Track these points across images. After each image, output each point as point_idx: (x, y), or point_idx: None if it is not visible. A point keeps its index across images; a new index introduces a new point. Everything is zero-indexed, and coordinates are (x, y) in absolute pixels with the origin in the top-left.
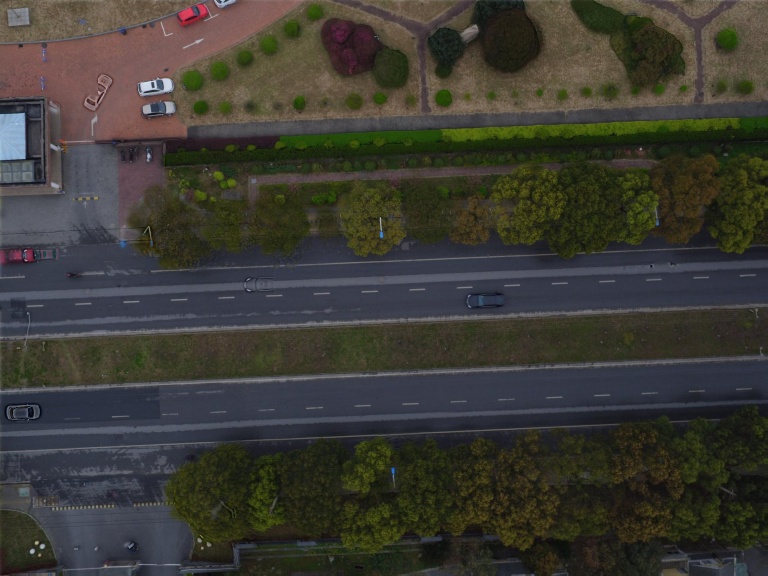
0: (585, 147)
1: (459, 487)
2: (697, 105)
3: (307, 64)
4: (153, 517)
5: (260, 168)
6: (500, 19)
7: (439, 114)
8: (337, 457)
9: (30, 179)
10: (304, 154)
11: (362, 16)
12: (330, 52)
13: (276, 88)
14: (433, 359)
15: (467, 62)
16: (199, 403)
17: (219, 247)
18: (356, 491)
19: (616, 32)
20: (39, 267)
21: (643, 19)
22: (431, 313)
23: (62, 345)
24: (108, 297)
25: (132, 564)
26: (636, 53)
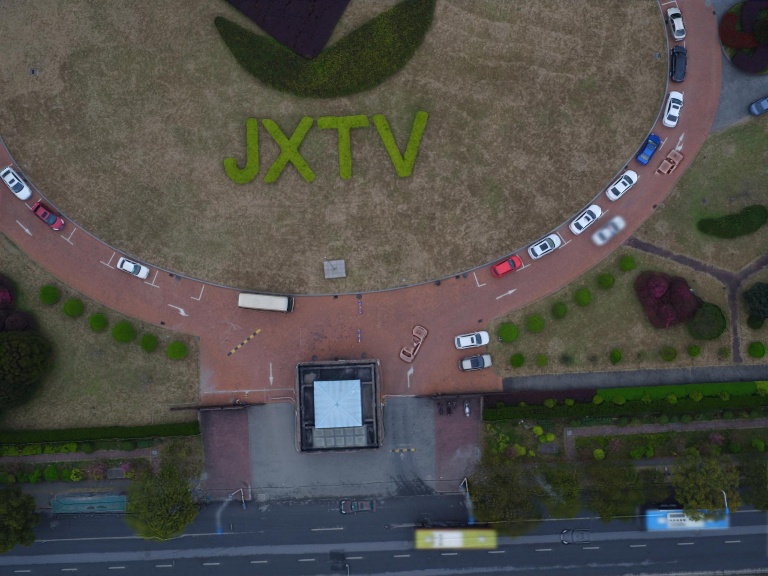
0: None
1: None
2: None
3: (620, 315)
4: None
5: (578, 422)
6: None
7: (750, 364)
8: None
9: (363, 443)
10: (623, 410)
11: (673, 266)
12: (646, 306)
13: (590, 339)
14: None
15: None
16: None
17: (539, 502)
18: None
19: None
20: (357, 518)
21: None
22: (746, 565)
23: None
24: (426, 549)
25: None
26: None
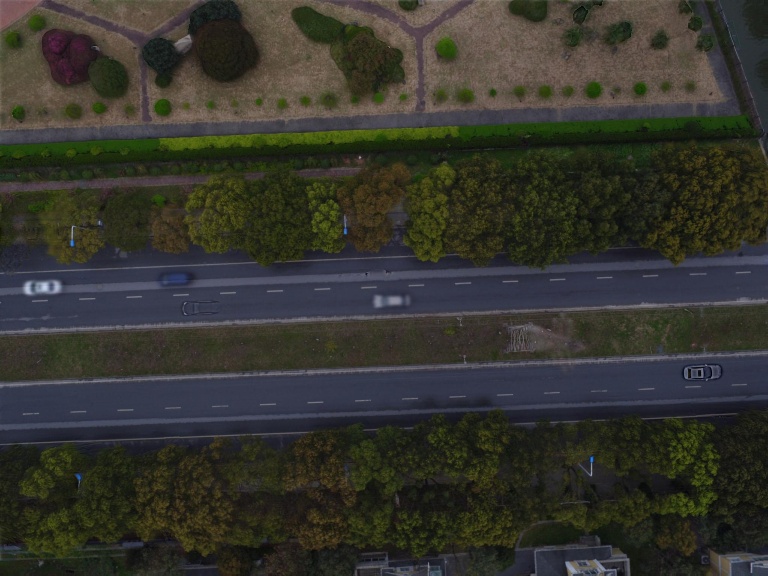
0: (300, 156)
1: (137, 493)
2: (419, 114)
3: (29, 74)
4: None
5: None
6: (204, 29)
7: (160, 123)
8: (22, 463)
9: None
10: (20, 163)
11: (85, 26)
12: (49, 62)
13: None
14: (147, 366)
15: (187, 72)
16: None
17: None
18: (34, 497)
19: (335, 41)
20: None
21: (358, 29)
22: (147, 320)
23: None
24: None
25: None
26: (350, 62)
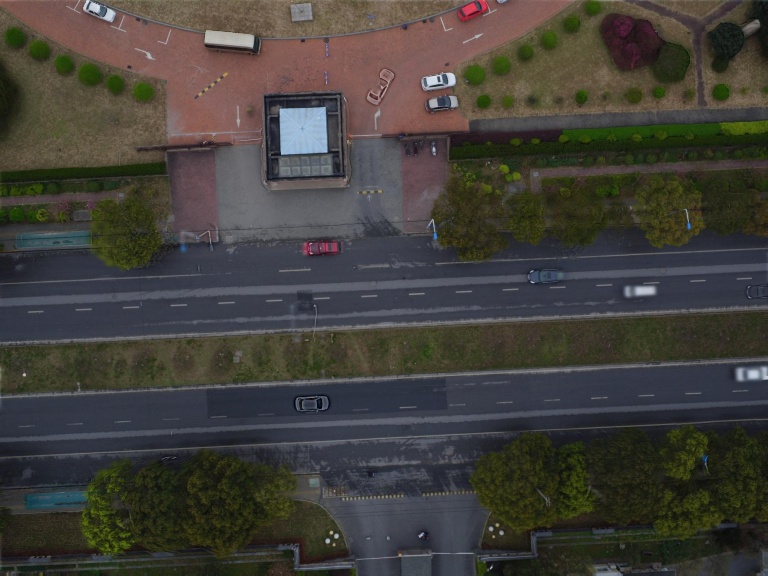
0: None
1: None
2: None
3: (586, 59)
4: (442, 506)
5: (545, 161)
6: None
7: (715, 108)
8: (653, 445)
9: (329, 172)
10: (589, 147)
11: (638, 11)
12: (611, 47)
13: (556, 82)
14: (715, 349)
15: (742, 57)
16: (486, 394)
17: (505, 239)
18: (678, 478)
19: None
20: (324, 260)
21: None
22: (712, 304)
23: (350, 337)
24: (394, 289)
25: (426, 553)
26: None
